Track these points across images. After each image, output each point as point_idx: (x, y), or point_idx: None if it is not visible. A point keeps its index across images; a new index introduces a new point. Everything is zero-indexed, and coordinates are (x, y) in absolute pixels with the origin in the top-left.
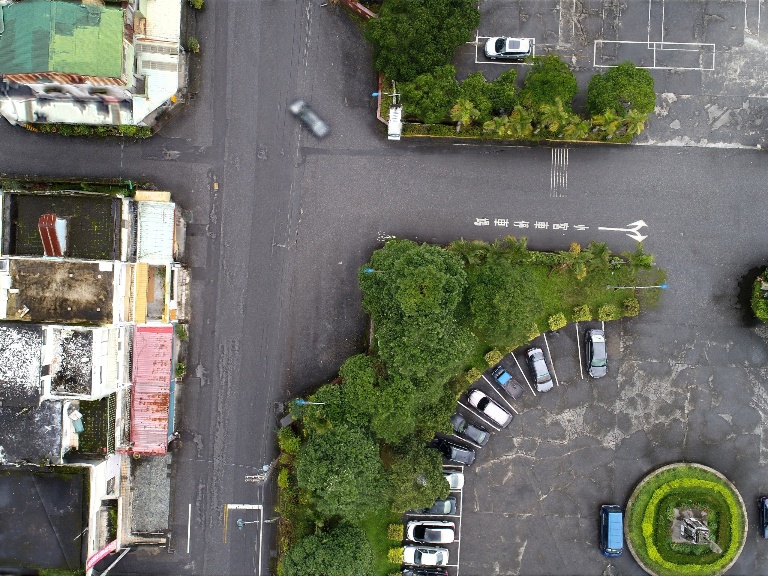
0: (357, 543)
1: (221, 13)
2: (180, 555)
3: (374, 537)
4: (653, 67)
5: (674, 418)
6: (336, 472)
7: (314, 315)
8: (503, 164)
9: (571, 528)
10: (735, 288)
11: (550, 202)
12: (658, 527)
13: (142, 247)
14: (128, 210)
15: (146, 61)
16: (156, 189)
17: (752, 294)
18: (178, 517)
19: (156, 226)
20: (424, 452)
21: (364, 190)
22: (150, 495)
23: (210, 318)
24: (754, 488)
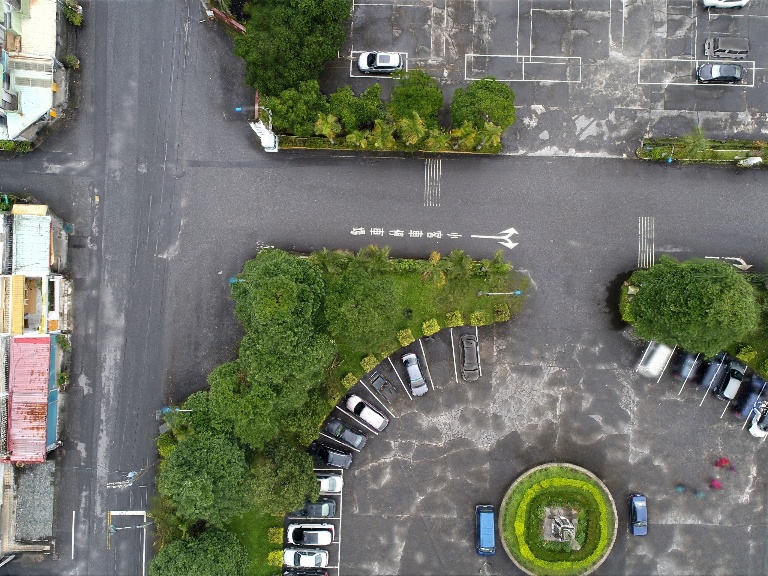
0: (223, 546)
1: (101, 30)
2: (65, 562)
3: (256, 540)
4: (522, 80)
5: (546, 419)
6: (192, 477)
7: (195, 324)
8: (378, 175)
9: (448, 528)
10: (603, 293)
11: (424, 211)
12: (530, 526)
13: (18, 260)
14: (3, 223)
15: (19, 78)
16: (37, 202)
17: (620, 298)
18: (62, 524)
19: (32, 239)
20: (294, 456)
21: (243, 201)
22: (34, 503)
23: (92, 328)
24: (624, 486)
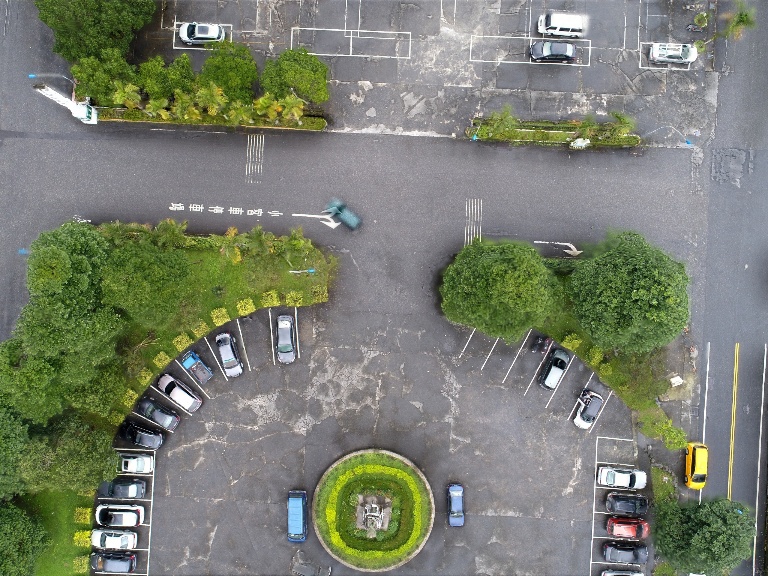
0: (3, 523)
1: None
2: None
3: (66, 520)
4: (349, 55)
5: (365, 405)
6: None
7: (8, 298)
8: (199, 149)
9: (261, 513)
10: (427, 276)
11: (245, 188)
12: (341, 513)
13: None
14: None
15: None
16: None
17: None
18: None
19: None
20: (88, 434)
21: (60, 174)
22: None
23: None
24: (444, 475)
